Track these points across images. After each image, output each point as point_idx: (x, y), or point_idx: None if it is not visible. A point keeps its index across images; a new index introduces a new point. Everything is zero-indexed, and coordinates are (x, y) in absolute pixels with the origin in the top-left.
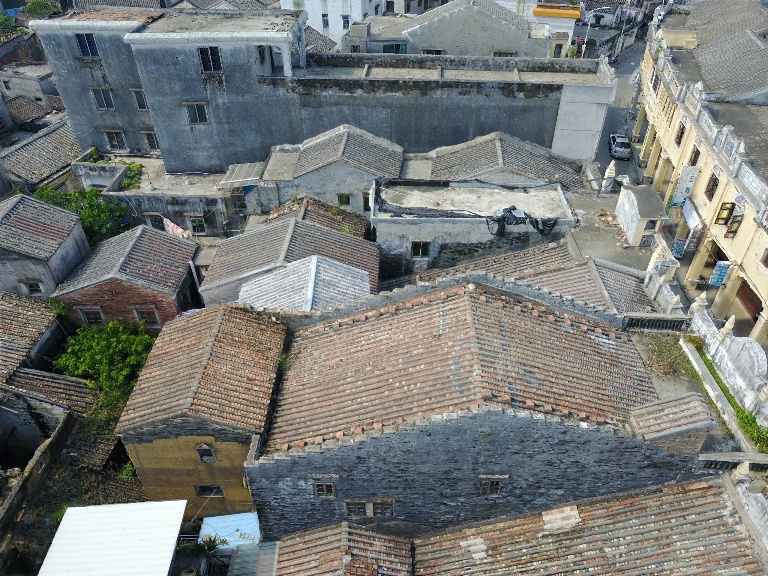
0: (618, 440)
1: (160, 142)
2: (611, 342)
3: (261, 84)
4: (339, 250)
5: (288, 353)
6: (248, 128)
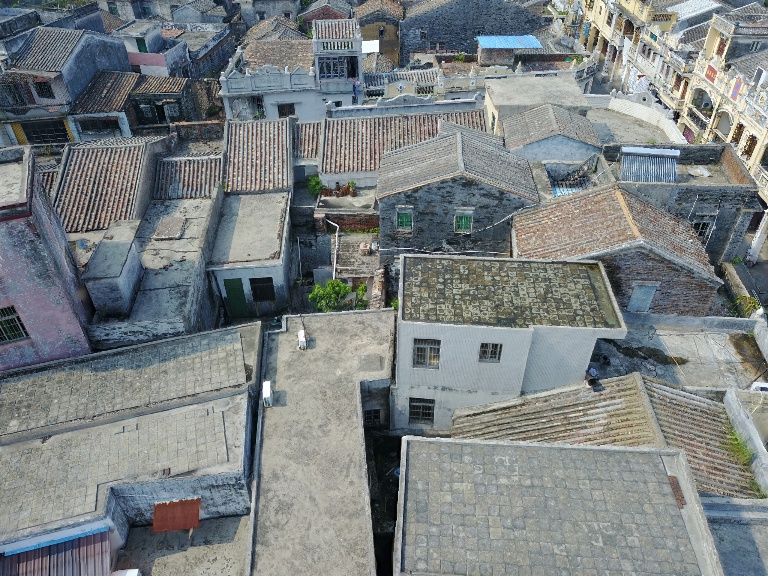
0: (516, 8)
1: None
2: None
3: None
4: None
5: None
6: None
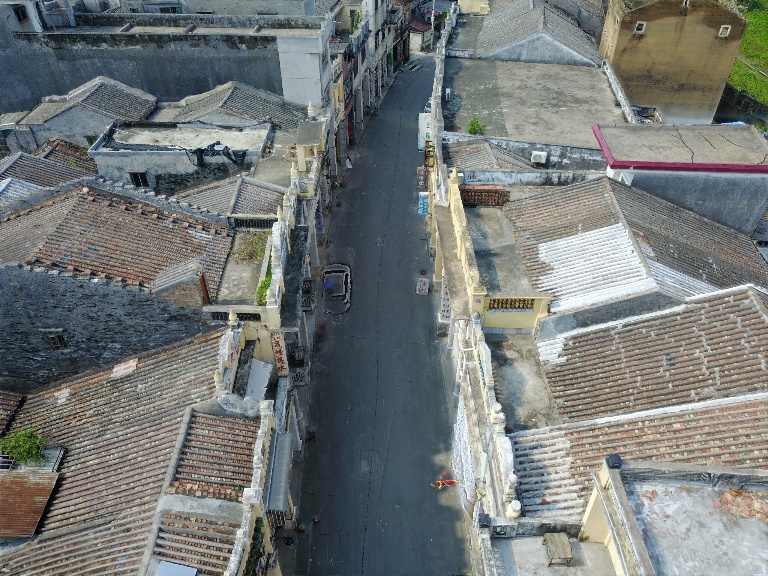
0: (130, 294)
1: None
2: (208, 236)
3: (17, 39)
4: (56, 179)
5: None
6: (16, 80)
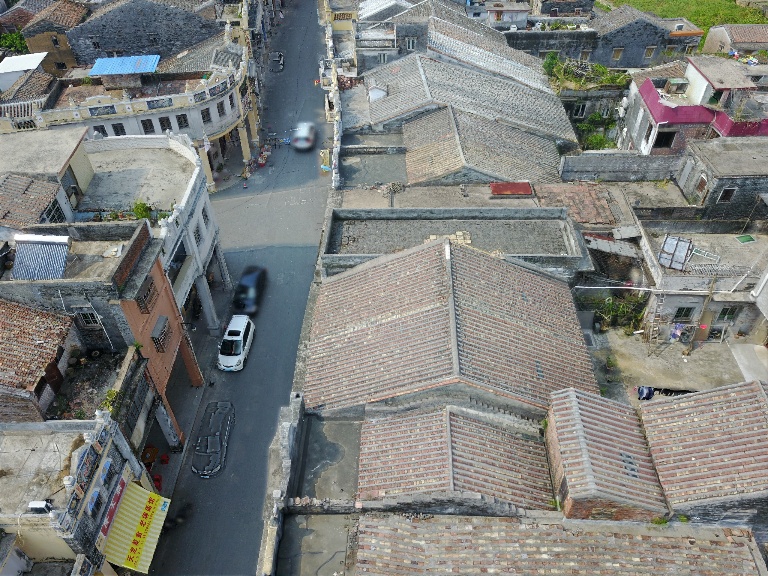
0: (186, 13)
1: None
2: None
3: None
4: None
5: (89, 16)
6: None
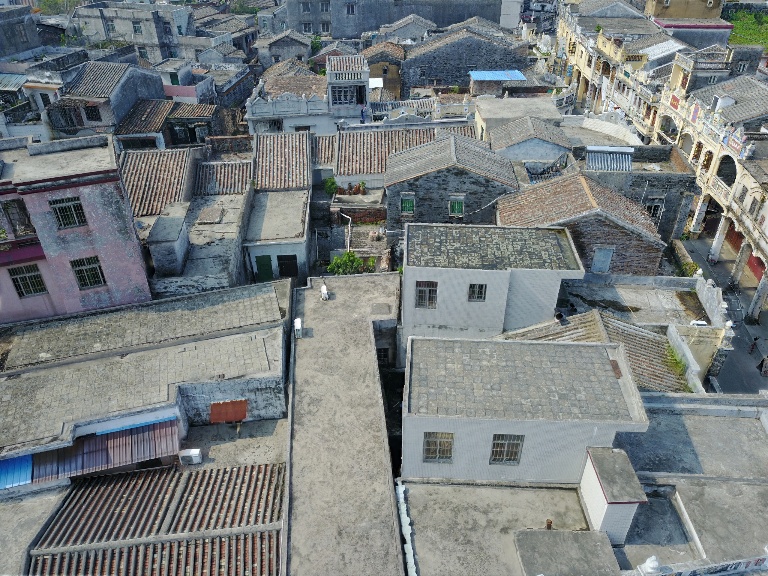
0: (505, 49)
1: (332, 23)
2: None
3: None
4: None
5: None
6: (371, 16)
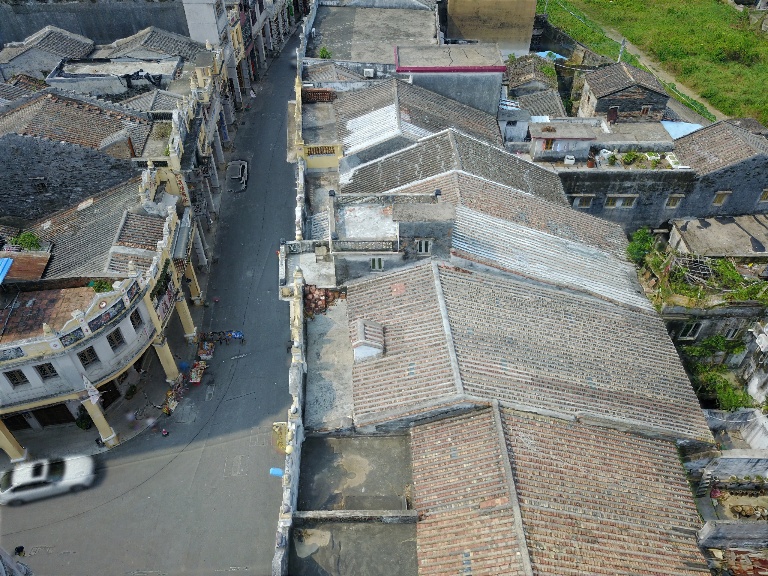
0: (85, 151)
1: None
2: (134, 124)
3: None
4: None
5: None
6: None
